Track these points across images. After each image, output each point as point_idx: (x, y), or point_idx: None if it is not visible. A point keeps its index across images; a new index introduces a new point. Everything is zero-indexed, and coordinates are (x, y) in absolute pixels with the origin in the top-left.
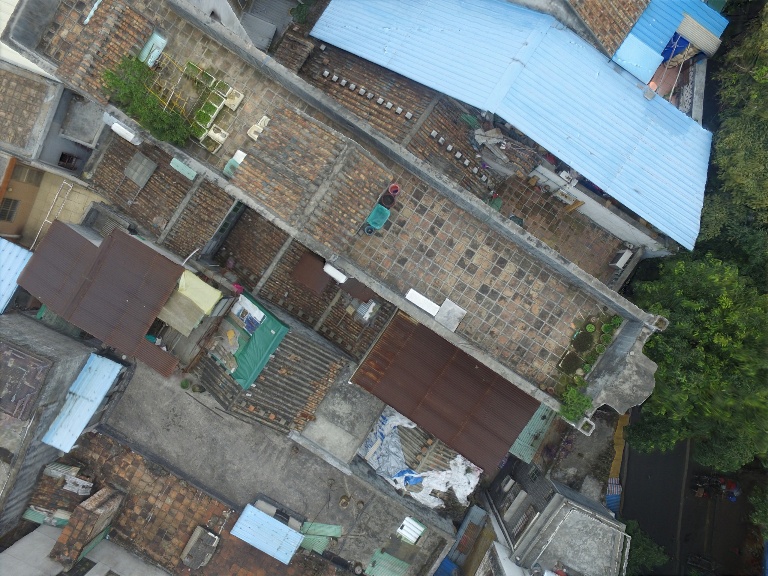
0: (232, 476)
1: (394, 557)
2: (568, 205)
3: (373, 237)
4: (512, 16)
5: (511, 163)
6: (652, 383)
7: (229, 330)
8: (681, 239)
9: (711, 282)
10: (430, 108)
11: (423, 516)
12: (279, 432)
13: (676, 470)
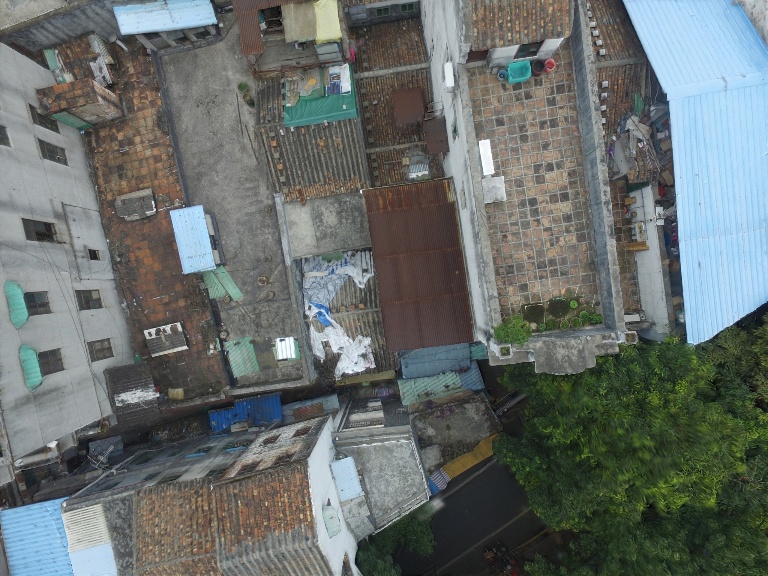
0: (208, 182)
1: (255, 354)
2: (634, 243)
3: (499, 84)
4: (754, 51)
5: (634, 160)
6: (581, 368)
7: (314, 78)
8: (691, 331)
9: (688, 360)
10: (623, 62)
11: (305, 345)
12: (272, 184)
13: (489, 525)
